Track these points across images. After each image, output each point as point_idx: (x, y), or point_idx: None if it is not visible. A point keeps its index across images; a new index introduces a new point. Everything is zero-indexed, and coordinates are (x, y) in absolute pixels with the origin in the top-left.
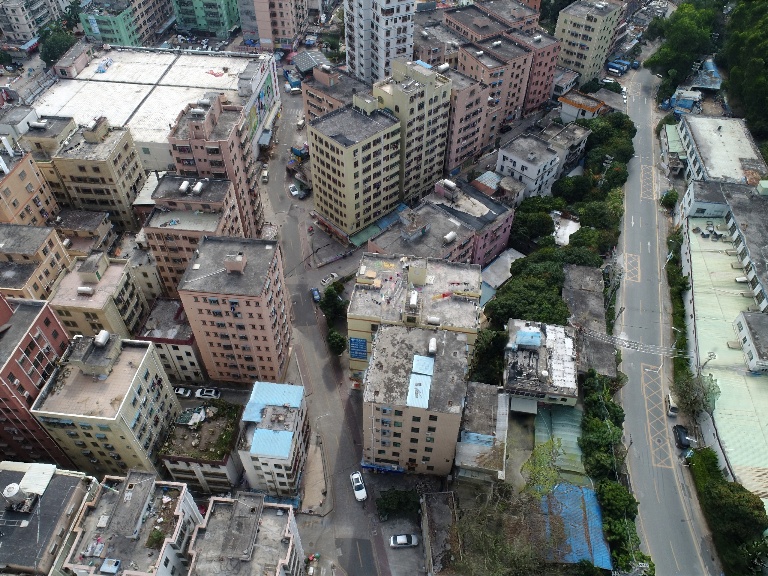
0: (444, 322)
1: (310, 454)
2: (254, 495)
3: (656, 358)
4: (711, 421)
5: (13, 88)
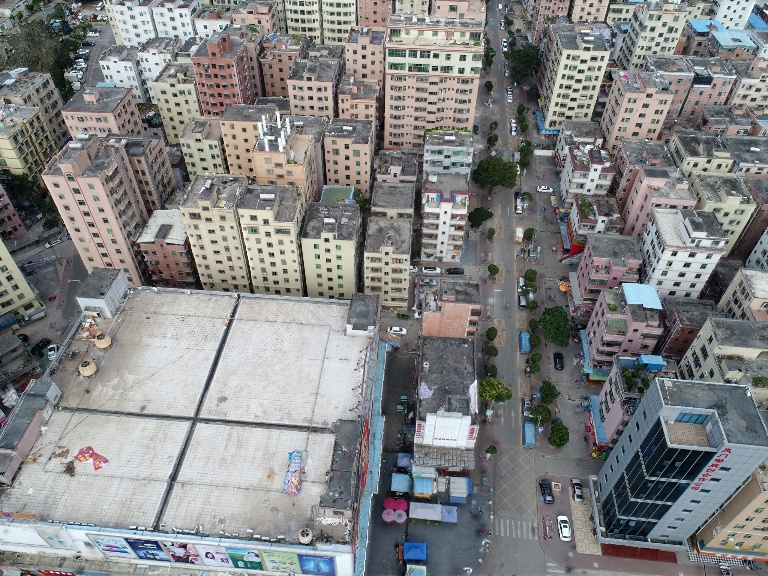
0: None
1: None
2: (111, 56)
3: None
4: None
5: None
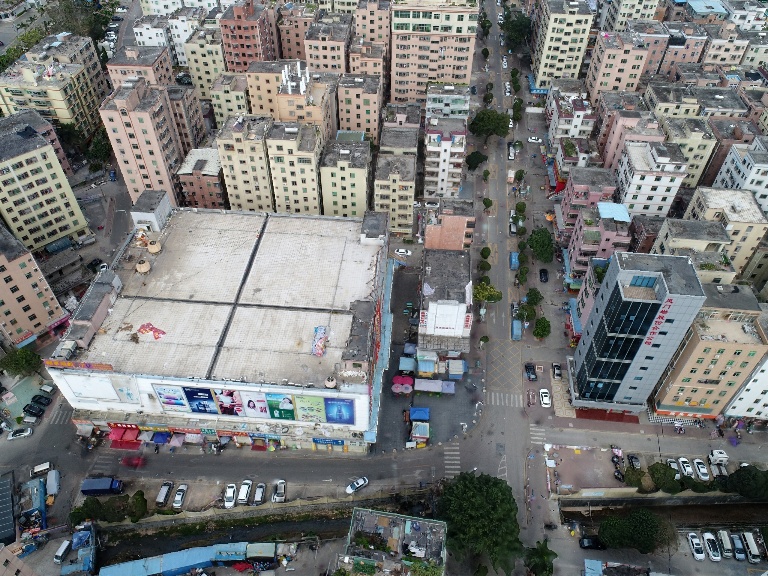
0: None
1: None
2: (144, 23)
3: None
4: None
5: (538, 459)
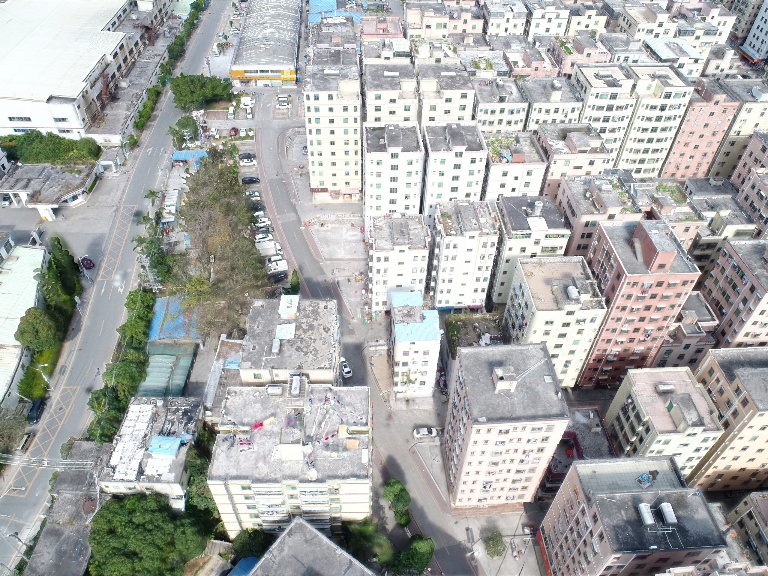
0: (263, 396)
1: (393, 392)
2: (400, 244)
3: (1, 508)
4: (3, 404)
5: None
